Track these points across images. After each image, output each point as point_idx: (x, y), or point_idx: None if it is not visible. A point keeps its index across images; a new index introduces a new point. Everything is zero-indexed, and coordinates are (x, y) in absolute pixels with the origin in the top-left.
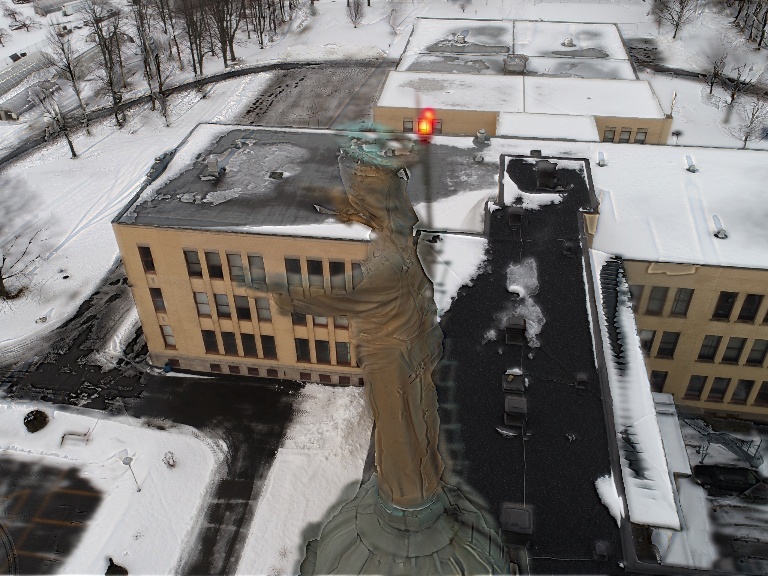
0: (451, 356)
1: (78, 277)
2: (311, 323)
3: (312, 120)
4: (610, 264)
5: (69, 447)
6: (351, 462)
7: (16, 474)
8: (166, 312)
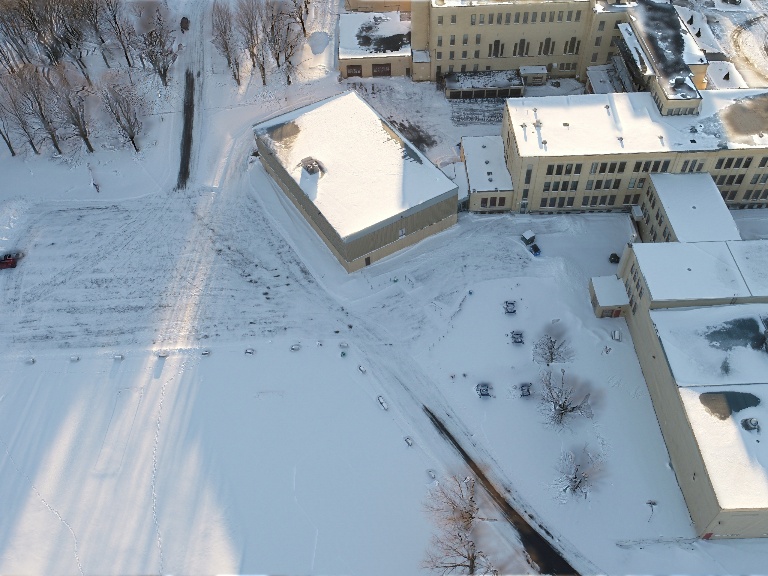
0: None
1: None
2: None
3: None
4: None
5: None
6: None
7: None
8: None
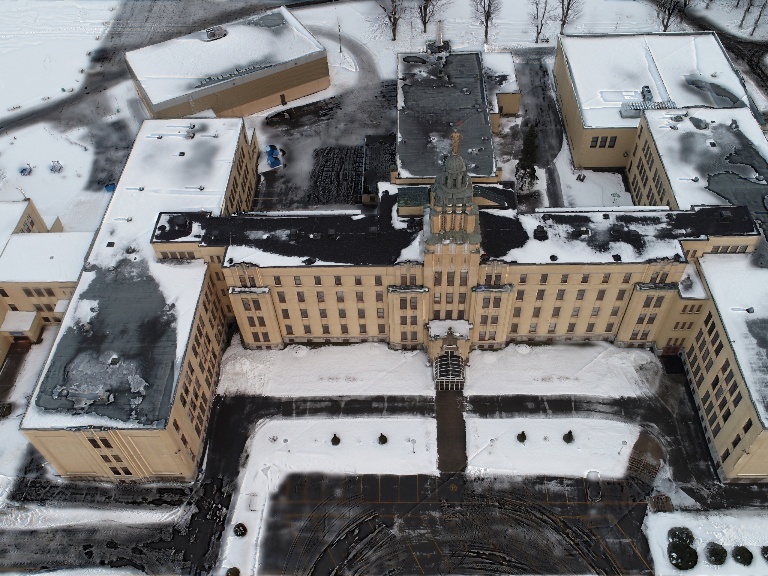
0: (305, 252)
1: None
2: None
3: None
4: (239, 215)
5: (258, 506)
6: (273, 362)
7: (275, 529)
8: (187, 443)
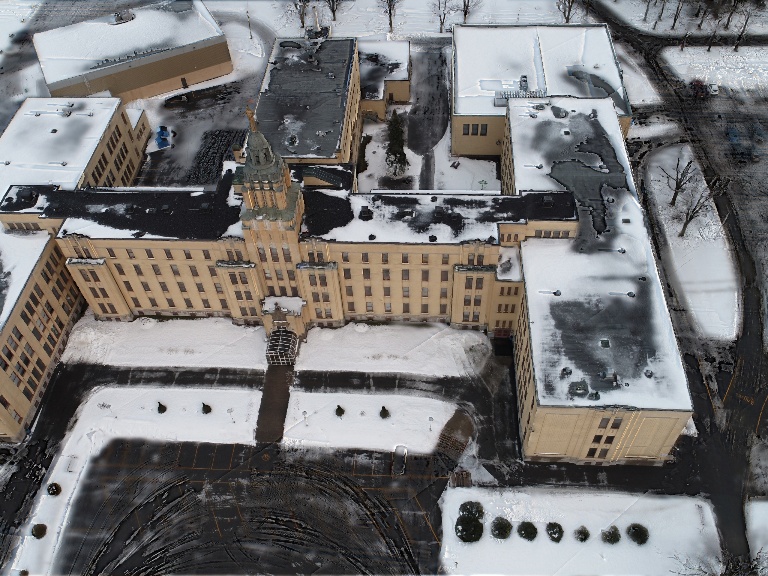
0: (137, 225)
1: None
2: (42, 333)
3: None
4: None
5: (77, 468)
6: (119, 333)
7: (89, 490)
8: (9, 405)
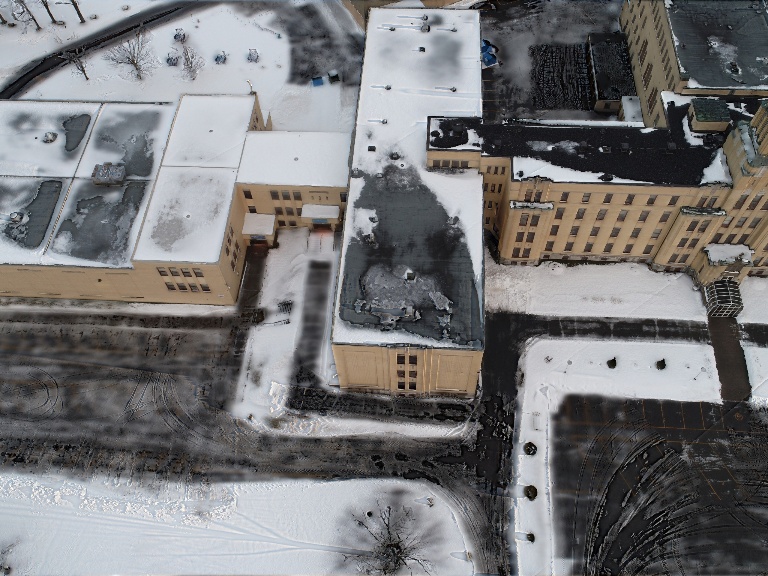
0: (598, 167)
1: (372, 502)
2: None
3: (66, 383)
4: (511, 122)
5: (541, 426)
6: (531, 279)
7: (563, 449)
8: None
